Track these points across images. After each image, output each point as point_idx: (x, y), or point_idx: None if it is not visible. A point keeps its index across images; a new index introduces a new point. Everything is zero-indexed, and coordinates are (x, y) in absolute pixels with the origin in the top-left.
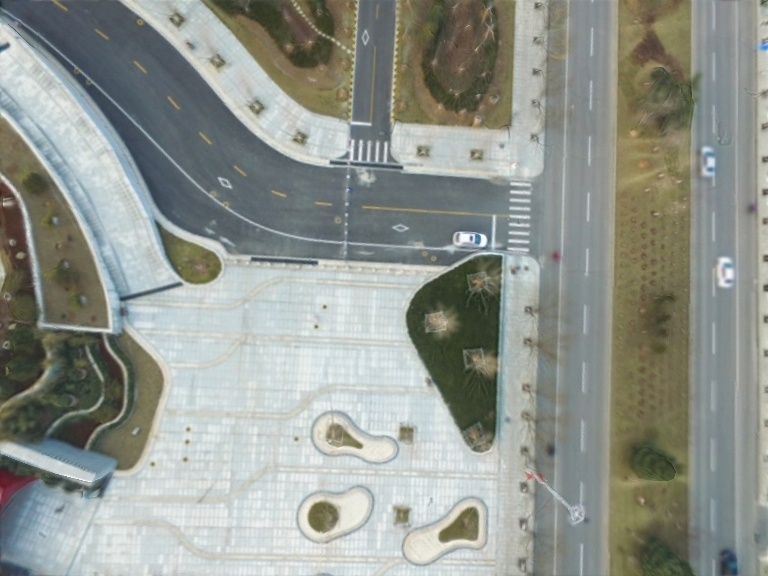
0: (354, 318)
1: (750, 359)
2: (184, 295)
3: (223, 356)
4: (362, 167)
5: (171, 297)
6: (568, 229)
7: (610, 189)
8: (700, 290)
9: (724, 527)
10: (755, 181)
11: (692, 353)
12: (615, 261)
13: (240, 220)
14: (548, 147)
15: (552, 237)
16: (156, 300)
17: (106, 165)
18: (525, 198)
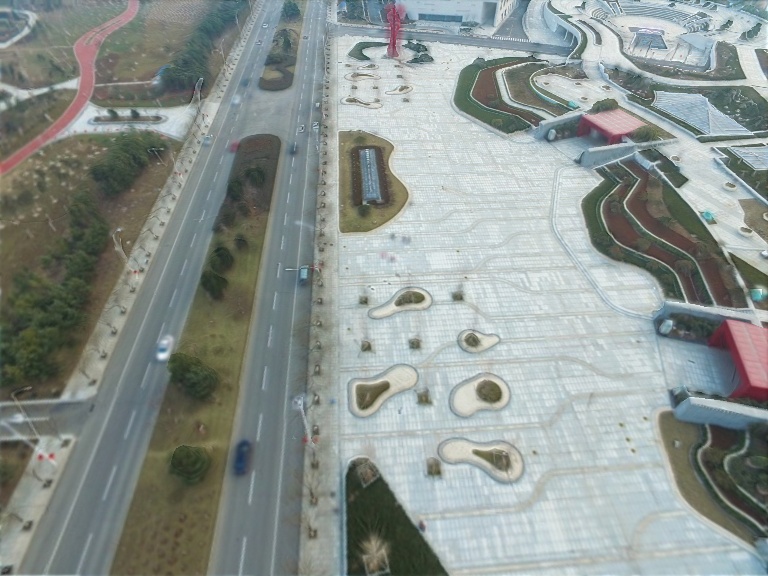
0: None
1: None
2: None
3: (640, 529)
4: None
5: None
6: None
7: None
8: None
9: (121, 414)
10: None
11: None
12: None
13: None
14: None
15: None
16: None
17: None
18: None
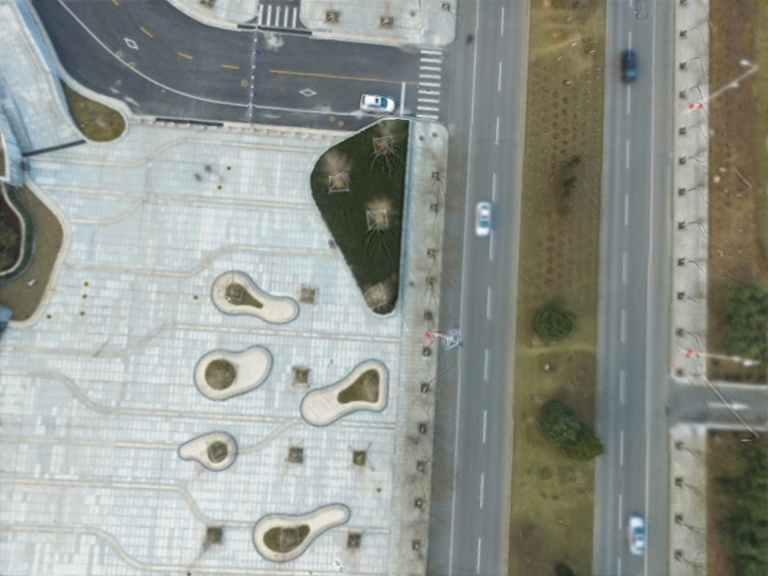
0: (258, 180)
1: (664, 232)
2: (87, 153)
3: (124, 214)
4: (270, 32)
5: (74, 154)
6: (479, 98)
7: (523, 59)
8: (613, 161)
9: (634, 399)
10: (673, 55)
11: (603, 223)
12: (526, 129)
13: (145, 81)
14: (460, 16)
15: (462, 105)
16: (59, 157)
17: (7, 16)
18: (435, 66)
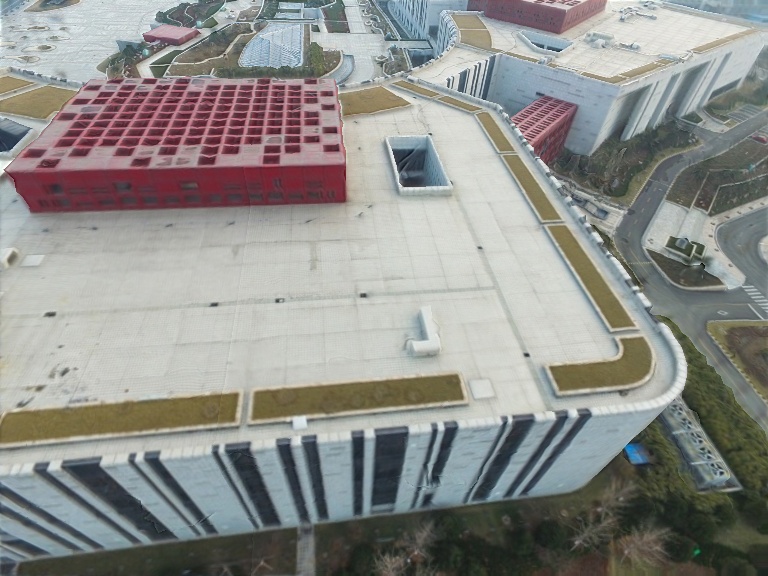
0: None
1: None
2: None
3: None
4: None
5: None
6: None
7: None
8: None
9: None
10: None
11: None
12: None
13: None
14: None
15: None
16: None
17: None
18: None
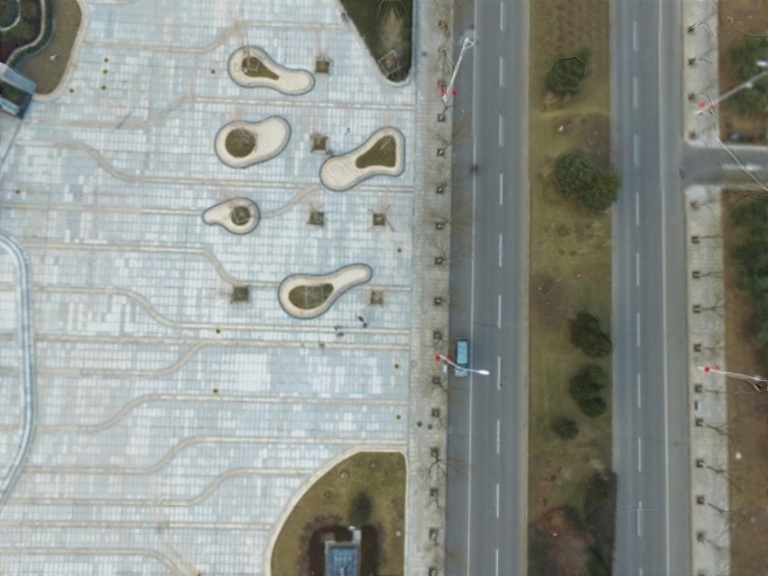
0: None
1: (674, 2)
2: None
3: None
4: None
5: None
6: None
7: None
8: None
9: (648, 162)
10: None
11: None
12: None
13: None
14: None
15: None
16: None
17: None
18: None
